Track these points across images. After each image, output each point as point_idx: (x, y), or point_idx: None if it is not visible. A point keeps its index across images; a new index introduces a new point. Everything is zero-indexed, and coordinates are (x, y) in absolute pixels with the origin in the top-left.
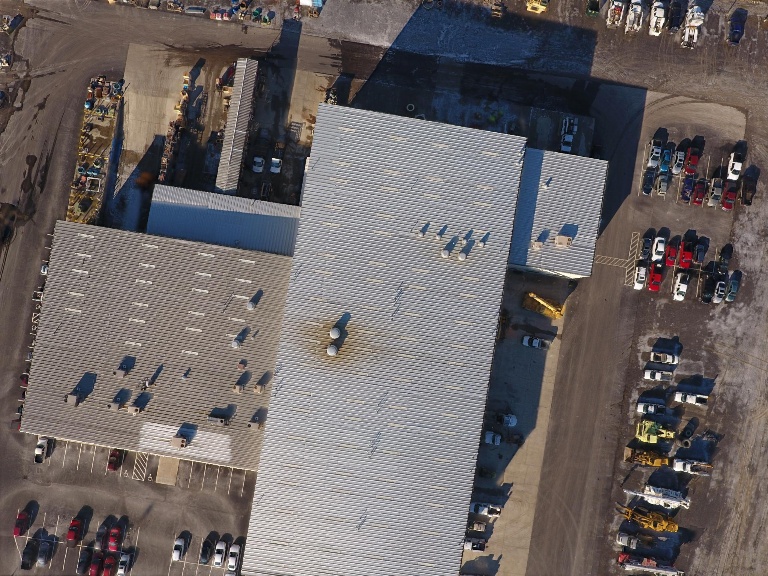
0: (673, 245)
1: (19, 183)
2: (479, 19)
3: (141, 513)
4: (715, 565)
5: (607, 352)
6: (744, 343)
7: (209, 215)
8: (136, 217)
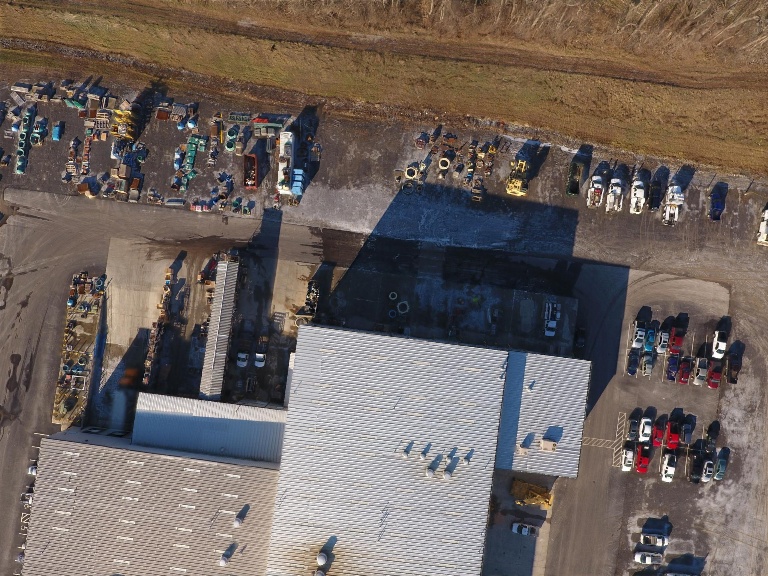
0: (660, 425)
1: (4, 382)
2: (459, 202)
3: None
4: None
5: (597, 534)
6: (734, 520)
7: (194, 422)
8: (122, 411)
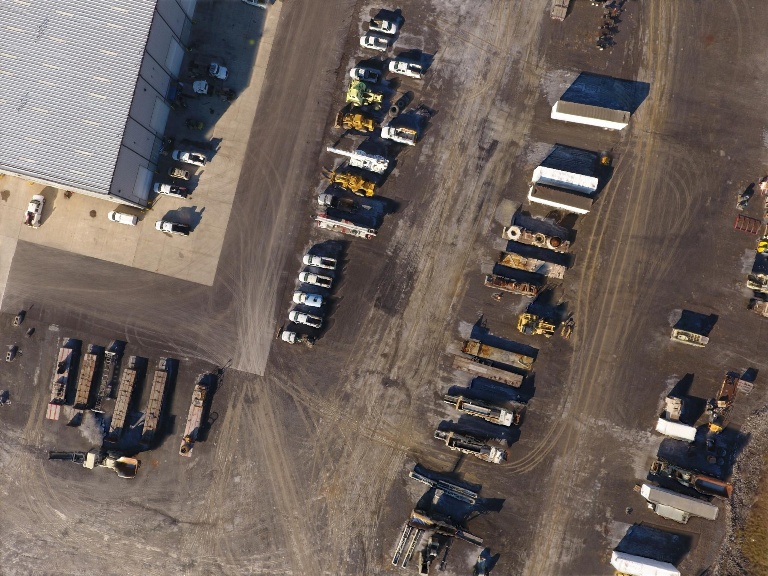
0: None
1: None
2: None
3: None
4: (417, 238)
5: (328, 18)
6: (467, 22)
7: None
8: None
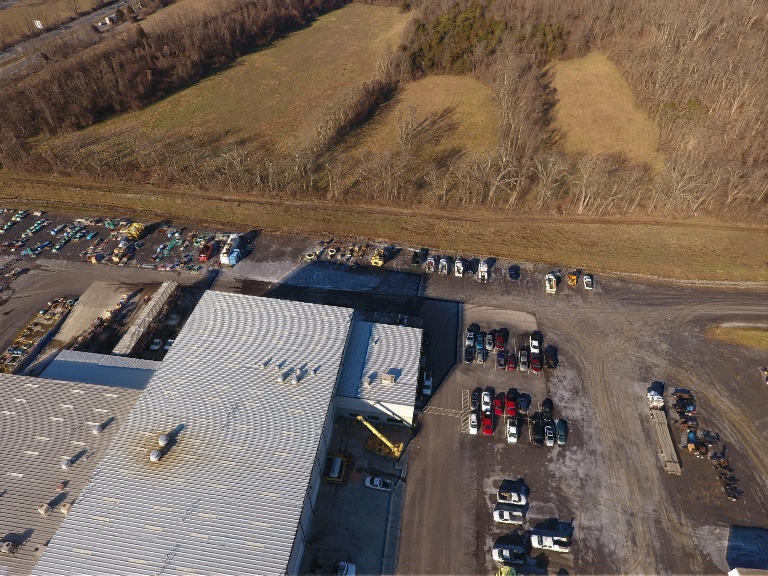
0: None
1: None
2: (340, 269)
3: None
4: None
5: (453, 494)
6: (589, 484)
7: (96, 369)
8: None
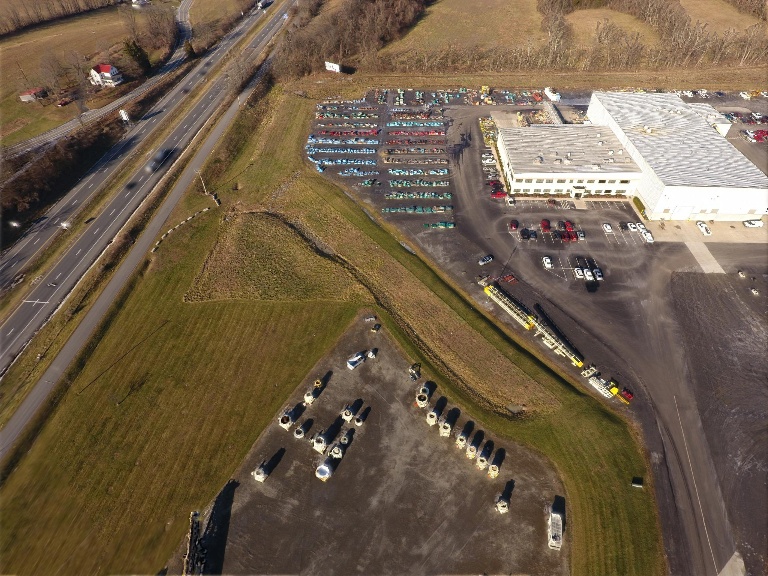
0: None
1: (460, 139)
2: None
3: (576, 219)
4: None
5: None
6: None
7: None
8: None
